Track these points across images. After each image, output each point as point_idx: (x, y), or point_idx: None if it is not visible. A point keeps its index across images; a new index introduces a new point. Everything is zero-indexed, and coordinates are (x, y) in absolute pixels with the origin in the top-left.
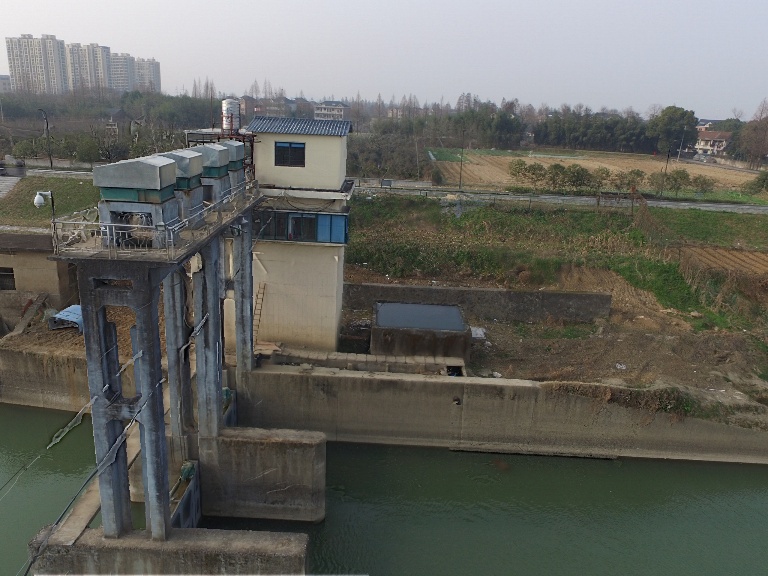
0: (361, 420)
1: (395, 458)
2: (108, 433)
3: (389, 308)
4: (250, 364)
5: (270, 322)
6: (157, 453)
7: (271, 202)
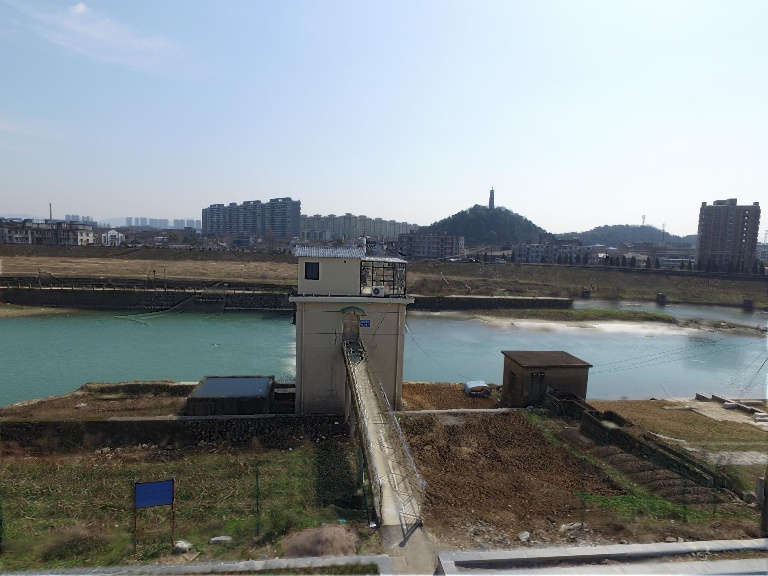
0: None
1: None
2: None
3: None
4: None
5: None
6: None
7: None
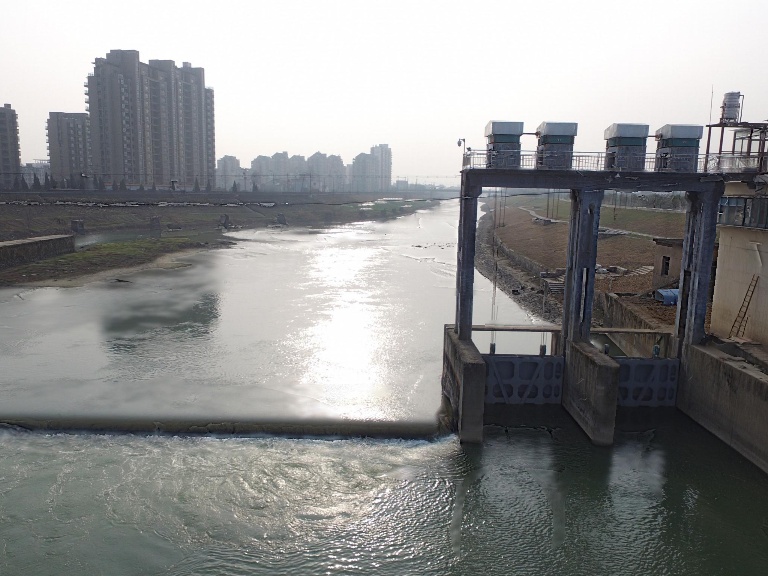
0: (750, 430)
1: (747, 480)
2: (459, 268)
3: None
4: (692, 337)
5: (757, 319)
6: (461, 282)
7: None
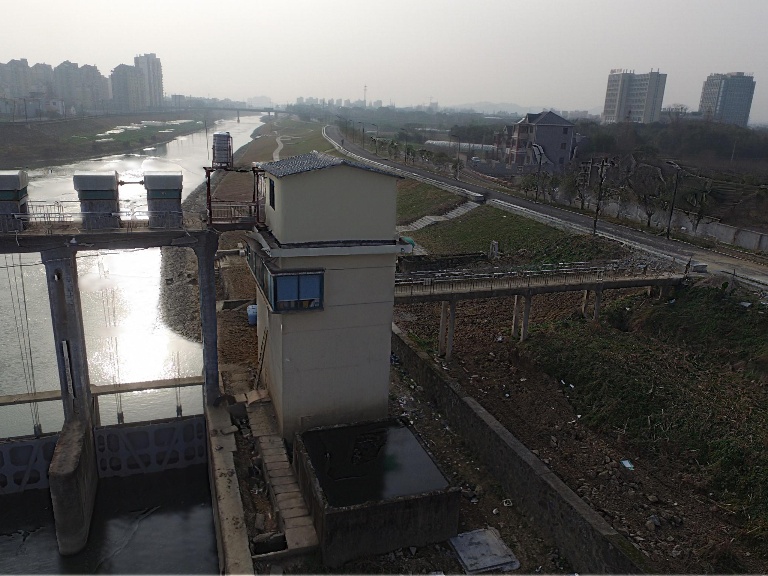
0: None
1: None
2: None
3: (405, 435)
4: (207, 397)
5: None
6: None
7: (182, 237)
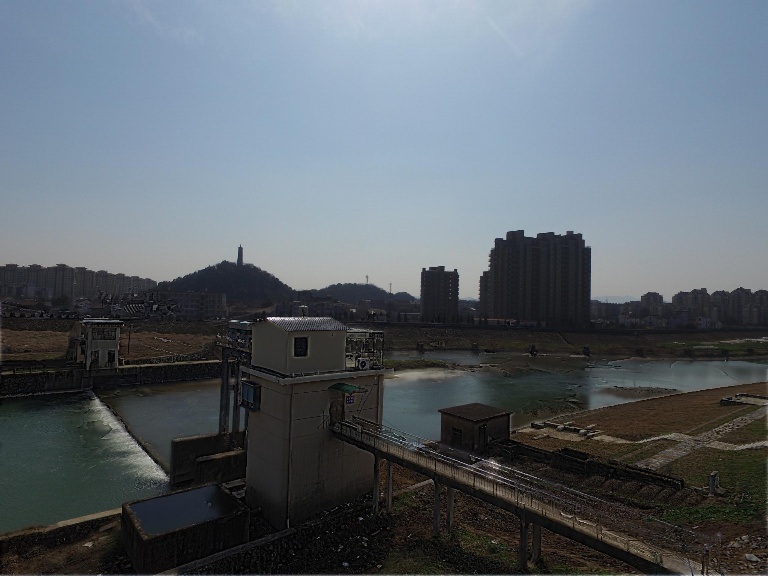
0: None
1: None
2: None
3: None
4: None
5: None
6: None
7: None
